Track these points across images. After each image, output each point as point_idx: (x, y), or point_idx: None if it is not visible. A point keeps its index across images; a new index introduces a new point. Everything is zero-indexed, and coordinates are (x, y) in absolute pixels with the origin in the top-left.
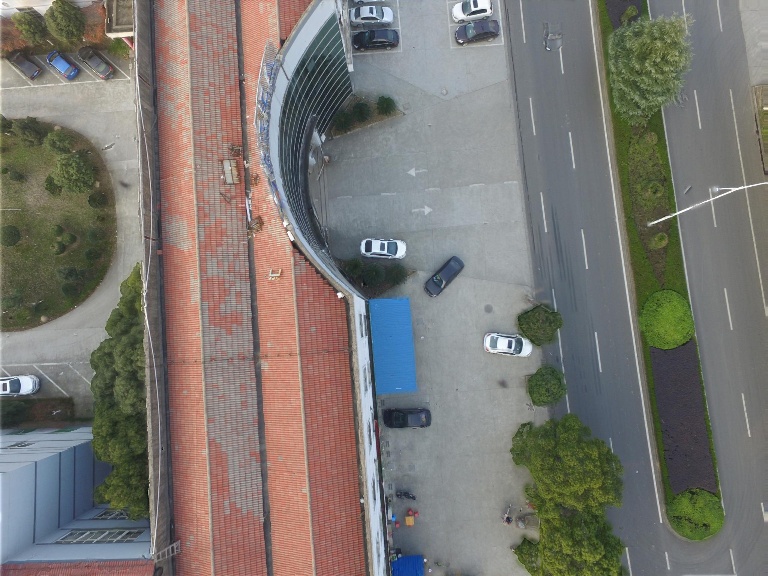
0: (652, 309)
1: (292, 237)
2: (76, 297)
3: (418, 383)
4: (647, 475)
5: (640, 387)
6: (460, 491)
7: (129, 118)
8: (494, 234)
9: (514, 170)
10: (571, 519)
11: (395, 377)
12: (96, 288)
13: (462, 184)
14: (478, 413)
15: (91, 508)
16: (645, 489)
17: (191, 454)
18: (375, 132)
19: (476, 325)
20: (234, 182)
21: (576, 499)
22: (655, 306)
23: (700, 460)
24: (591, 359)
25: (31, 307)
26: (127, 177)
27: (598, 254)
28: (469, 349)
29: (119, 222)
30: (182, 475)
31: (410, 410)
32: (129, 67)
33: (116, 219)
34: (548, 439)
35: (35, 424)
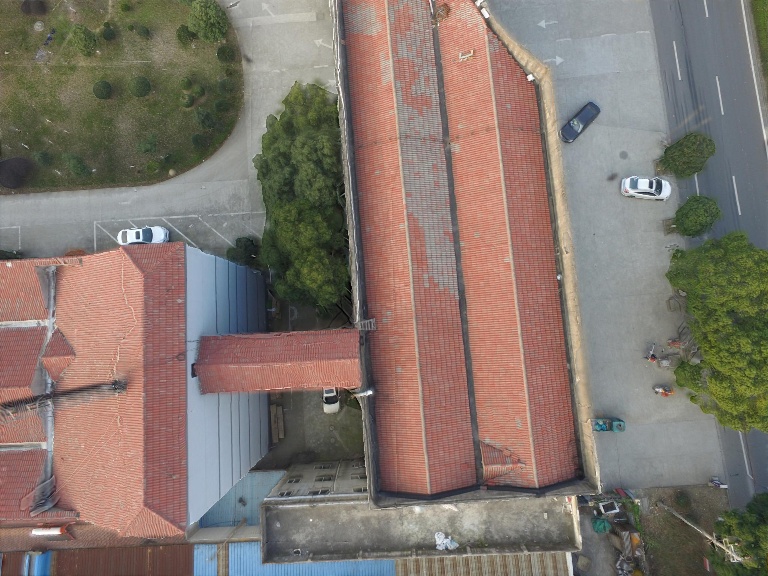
0: None
1: (487, 14)
2: (204, 151)
3: None
4: None
5: None
6: (600, 333)
7: None
8: (627, 83)
9: (646, 20)
10: (743, 325)
11: None
12: (224, 142)
13: (593, 35)
14: (617, 257)
15: (246, 331)
16: None
17: (386, 231)
18: None
19: (612, 171)
20: None
21: (751, 302)
22: None
23: None
24: (729, 203)
25: (159, 161)
26: (253, 34)
27: (734, 100)
28: (605, 194)
29: (246, 77)
30: (375, 254)
31: None
32: None
33: (243, 75)
34: None
35: None
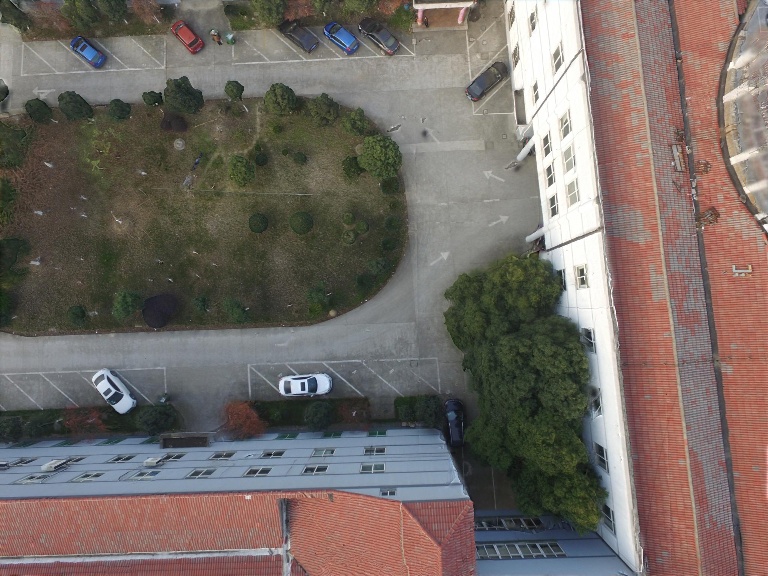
0: None
1: None
2: None
3: None
4: None
5: None
6: None
7: (416, 98)
8: None
9: None
10: None
11: None
12: (388, 280)
13: None
14: None
15: None
16: None
17: (660, 464)
18: None
19: None
20: (682, 169)
21: None
22: None
23: None
24: None
25: None
26: (417, 161)
27: None
28: None
29: (410, 210)
30: (646, 486)
31: None
32: (412, 42)
33: (406, 207)
34: None
35: (342, 426)
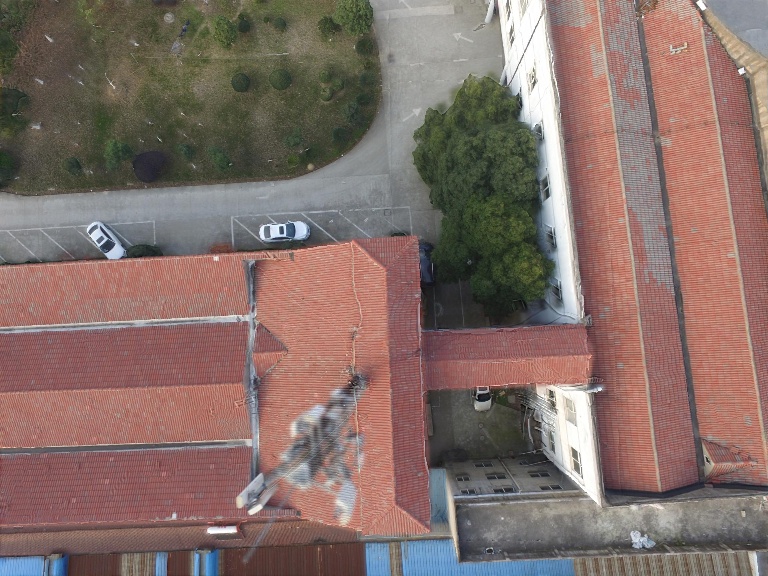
0: None
1: (703, 6)
2: (343, 145)
3: None
4: None
5: None
6: None
7: None
8: None
9: None
10: None
11: None
12: (363, 137)
13: (738, 30)
14: None
15: None
16: None
17: (602, 226)
18: None
19: None
20: None
21: None
22: None
23: None
24: None
25: (297, 155)
26: (390, 27)
27: None
28: None
29: (384, 71)
30: (589, 250)
31: None
32: None
33: (380, 68)
34: None
35: None
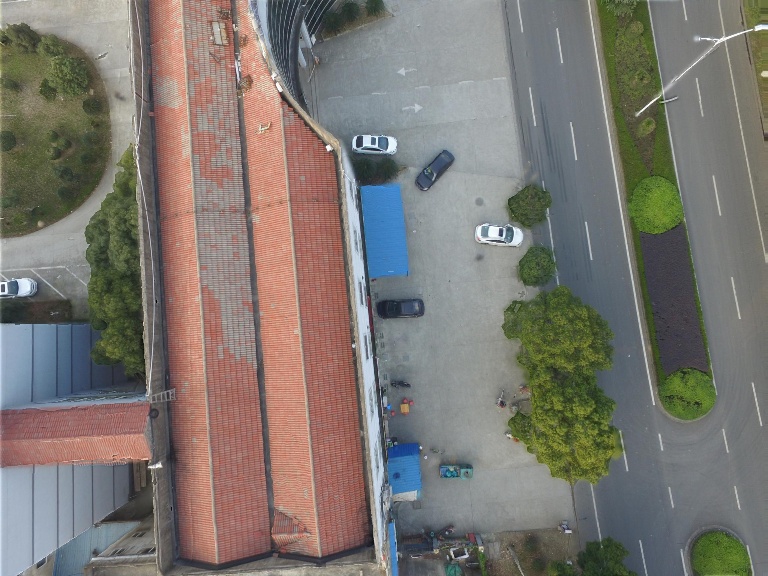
0: (641, 194)
1: (280, 88)
2: (72, 202)
3: (411, 275)
4: (639, 359)
5: (631, 274)
6: (454, 380)
7: (122, 28)
8: (484, 129)
9: (503, 67)
10: (562, 381)
11: (387, 261)
12: (92, 193)
13: (451, 82)
14: (471, 303)
15: (89, 389)
16: (637, 372)
17: (185, 303)
18: (365, 34)
19: (467, 218)
20: (223, 43)
21: (567, 359)
22: (644, 191)
23: (691, 340)
24: (582, 248)
25: (28, 213)
26: (121, 85)
27: (587, 145)
28: (461, 241)
29: (113, 128)
30: (176, 325)
31: (403, 299)
32: None
33: (110, 126)
34: (538, 305)
35: (33, 322)
